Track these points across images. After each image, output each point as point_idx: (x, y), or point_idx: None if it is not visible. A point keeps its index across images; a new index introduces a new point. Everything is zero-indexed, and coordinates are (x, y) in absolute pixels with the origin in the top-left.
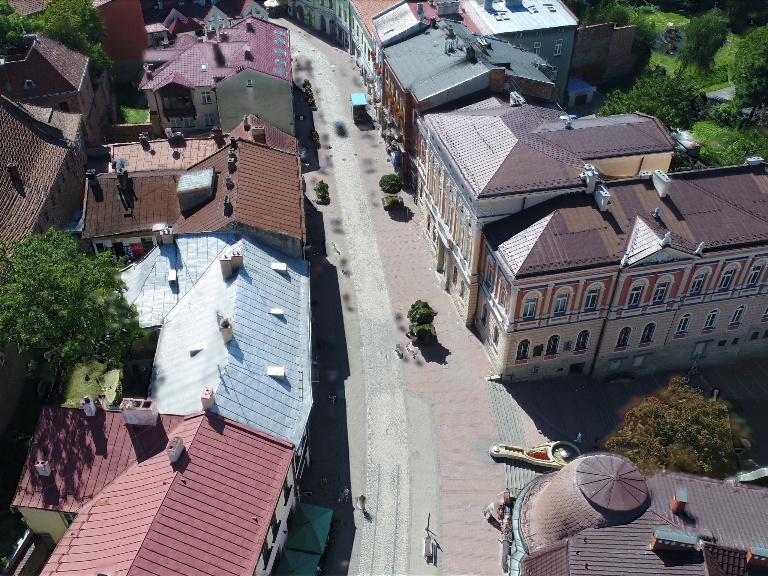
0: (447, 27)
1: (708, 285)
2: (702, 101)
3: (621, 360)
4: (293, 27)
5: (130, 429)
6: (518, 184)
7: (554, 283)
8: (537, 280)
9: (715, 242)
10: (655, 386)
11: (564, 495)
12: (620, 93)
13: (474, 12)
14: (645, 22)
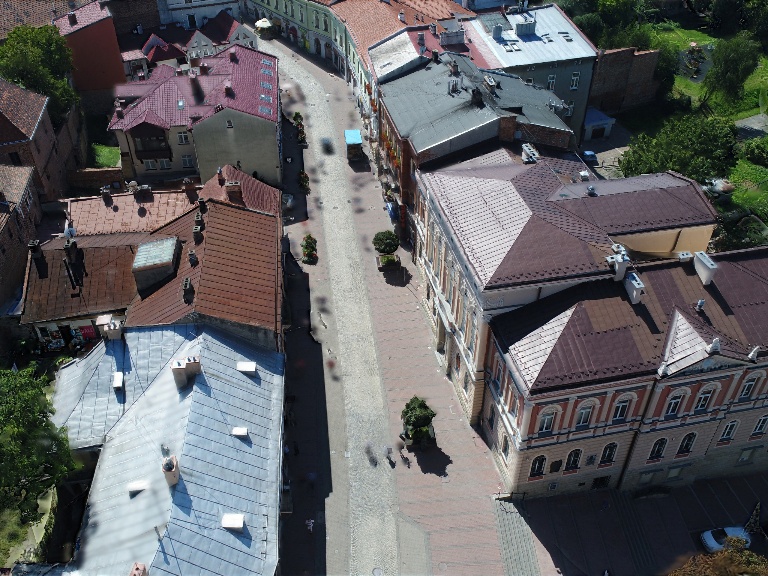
0: (450, 63)
1: (760, 390)
2: (740, 148)
3: (654, 472)
4: (286, 50)
5: None
6: (533, 271)
7: (576, 396)
8: (556, 393)
9: None
10: (694, 501)
11: None
12: (646, 137)
13: (481, 42)
14: (668, 47)
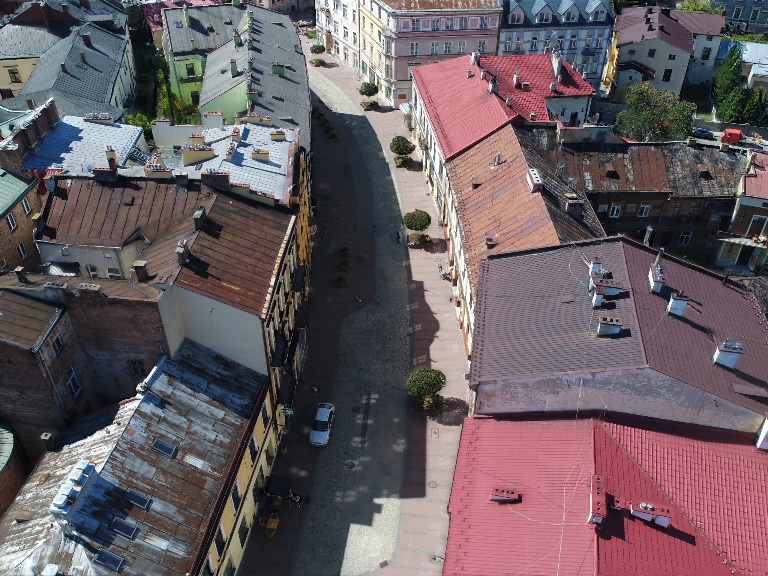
0: None
1: None
2: None
3: (307, 2)
4: None
5: (176, 4)
6: None
7: None
8: None
9: None
10: None
11: None
12: None
13: None
14: None
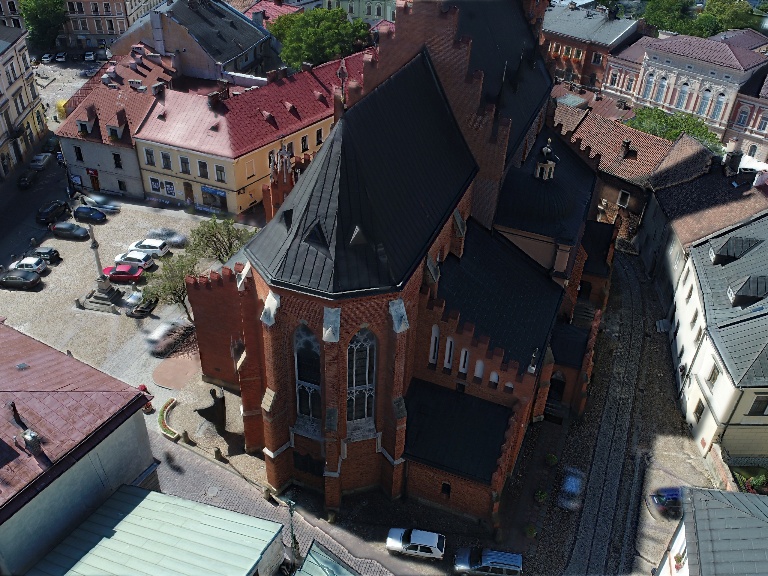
0: (572, 3)
1: None
2: None
3: None
4: None
5: None
6: (751, 63)
7: None
8: None
9: None
10: None
11: None
12: None
13: None
14: None
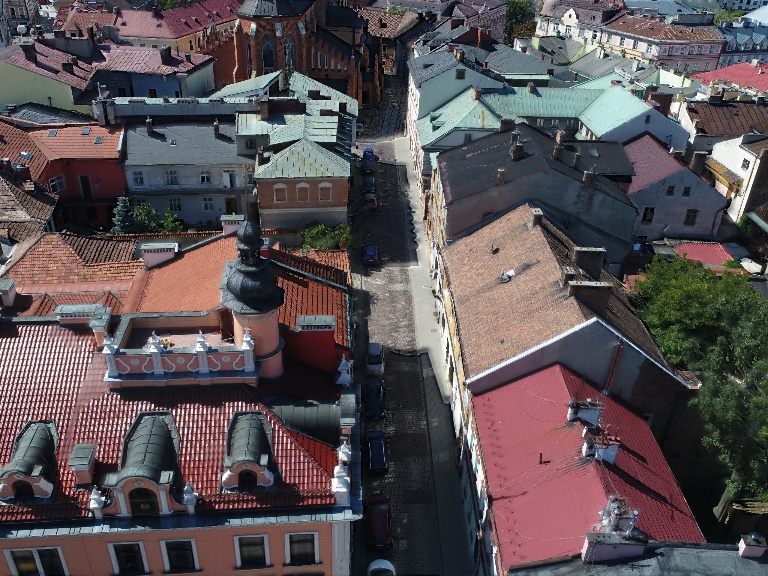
0: None
1: None
2: None
3: None
4: None
5: None
6: None
7: None
8: None
9: (489, 8)
10: None
11: (552, 1)
12: None
13: None
14: None
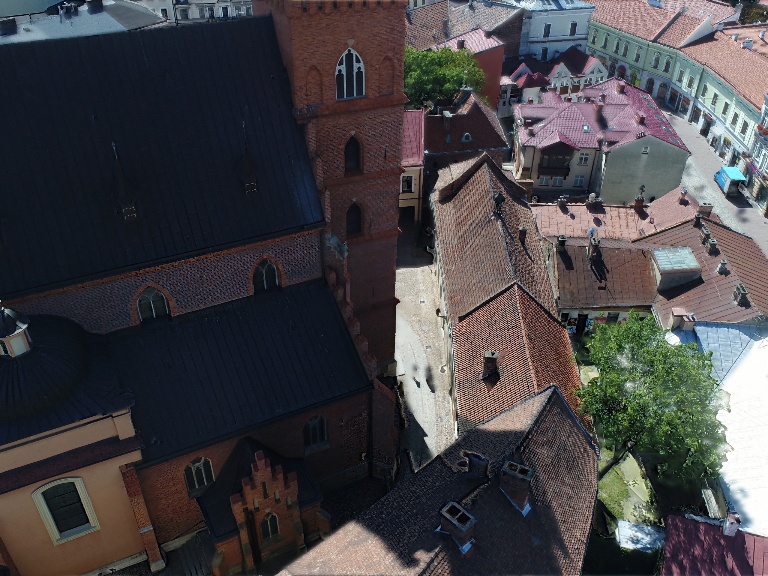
0: None
1: None
2: None
3: None
4: None
5: None
6: None
7: None
8: None
9: None
10: None
11: None
12: None
13: None
14: None
